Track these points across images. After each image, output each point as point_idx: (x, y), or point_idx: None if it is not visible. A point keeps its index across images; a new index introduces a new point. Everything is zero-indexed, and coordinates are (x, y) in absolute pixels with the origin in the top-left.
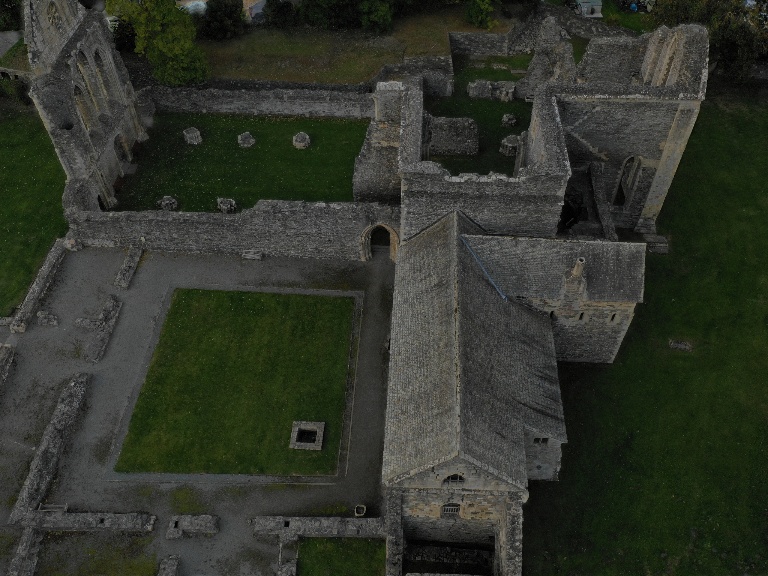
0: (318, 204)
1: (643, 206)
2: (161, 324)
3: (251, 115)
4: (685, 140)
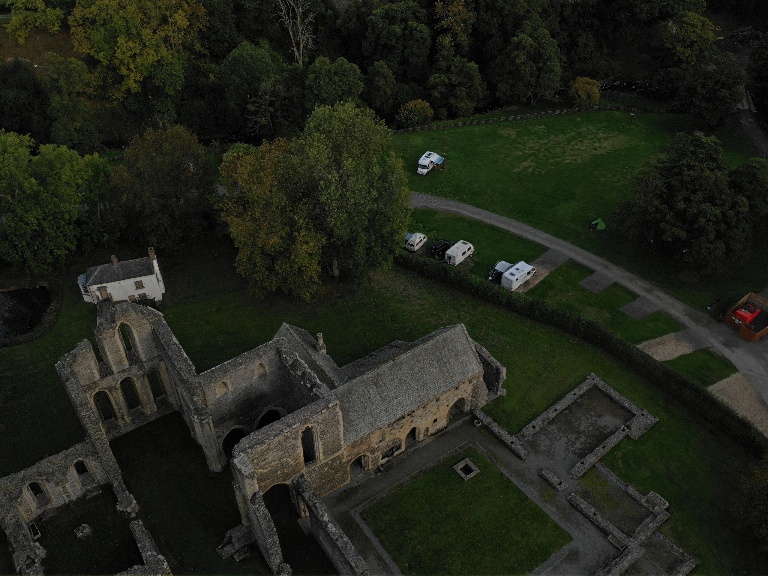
0: (332, 528)
1: None
2: None
3: None
4: None
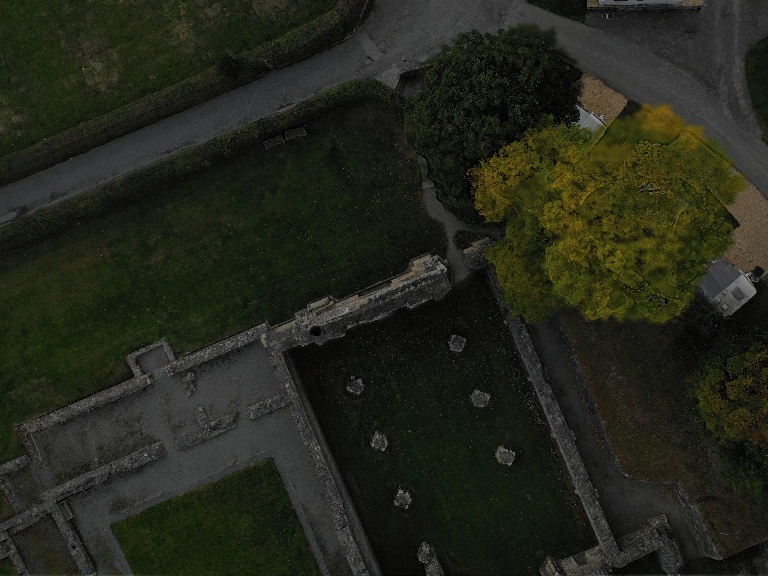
0: None
1: None
2: (234, 471)
3: (525, 374)
4: None
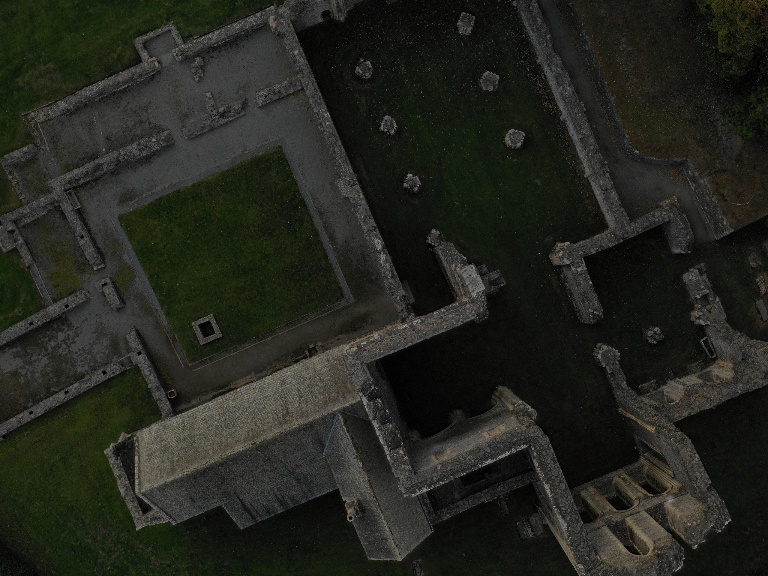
0: (377, 242)
1: (546, 515)
2: (242, 160)
3: (535, 57)
4: None
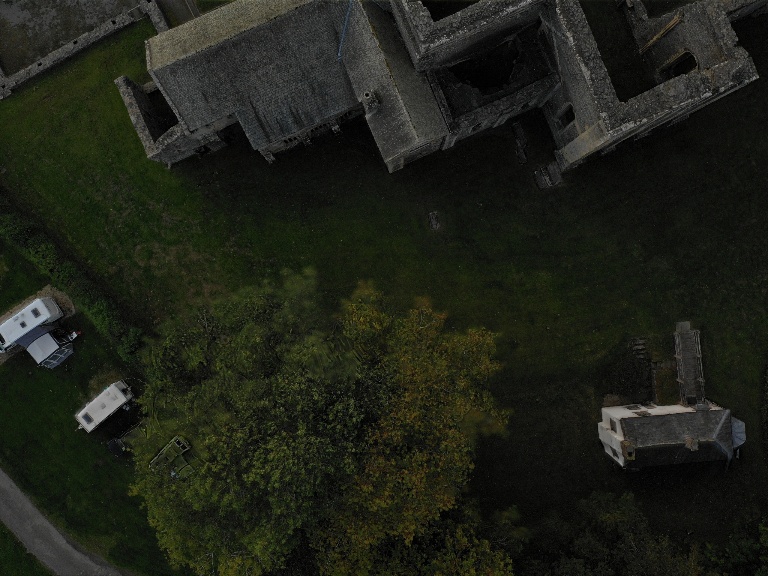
0: None
1: None
2: None
3: None
4: (594, 145)
